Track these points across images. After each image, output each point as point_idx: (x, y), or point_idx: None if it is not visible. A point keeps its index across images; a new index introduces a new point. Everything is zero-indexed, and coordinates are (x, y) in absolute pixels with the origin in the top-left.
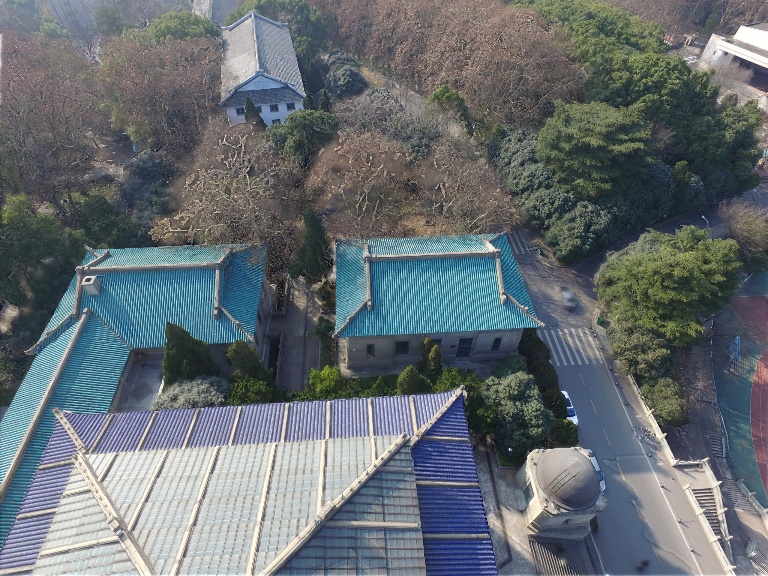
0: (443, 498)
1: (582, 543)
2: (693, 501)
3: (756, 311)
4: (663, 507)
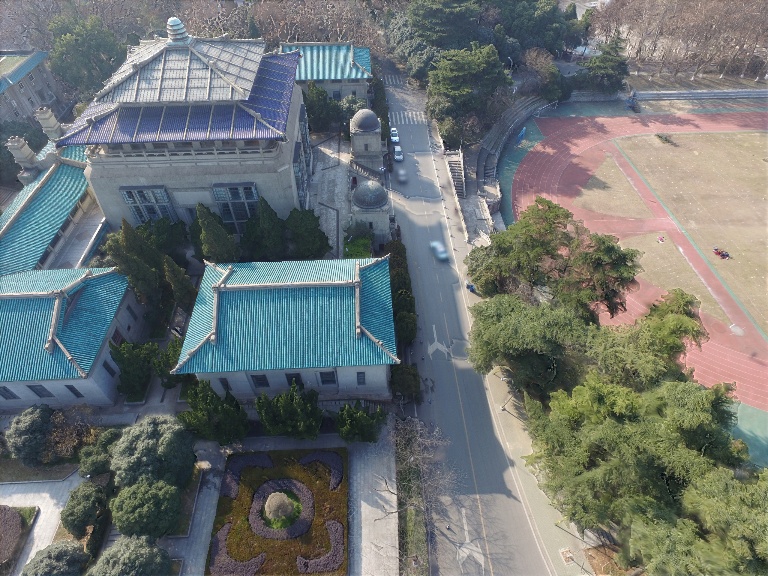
0: (279, 67)
1: (383, 175)
2: (446, 162)
3: (550, 123)
4: (431, 166)
